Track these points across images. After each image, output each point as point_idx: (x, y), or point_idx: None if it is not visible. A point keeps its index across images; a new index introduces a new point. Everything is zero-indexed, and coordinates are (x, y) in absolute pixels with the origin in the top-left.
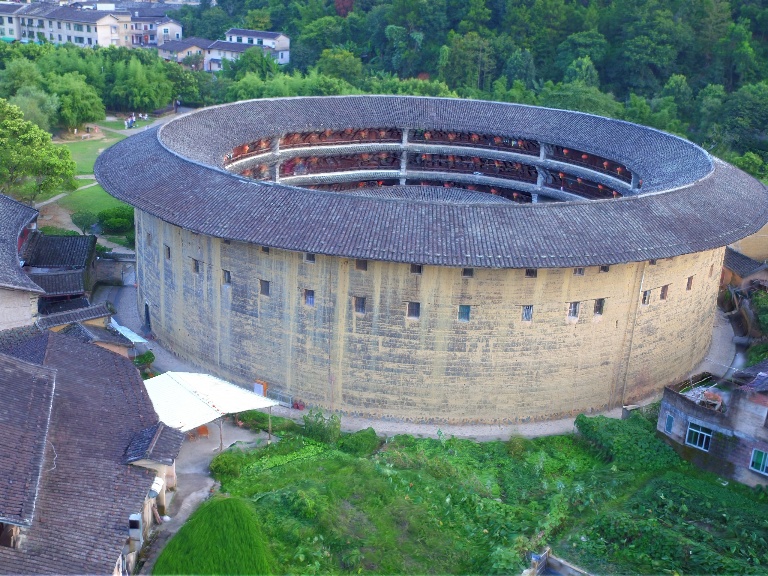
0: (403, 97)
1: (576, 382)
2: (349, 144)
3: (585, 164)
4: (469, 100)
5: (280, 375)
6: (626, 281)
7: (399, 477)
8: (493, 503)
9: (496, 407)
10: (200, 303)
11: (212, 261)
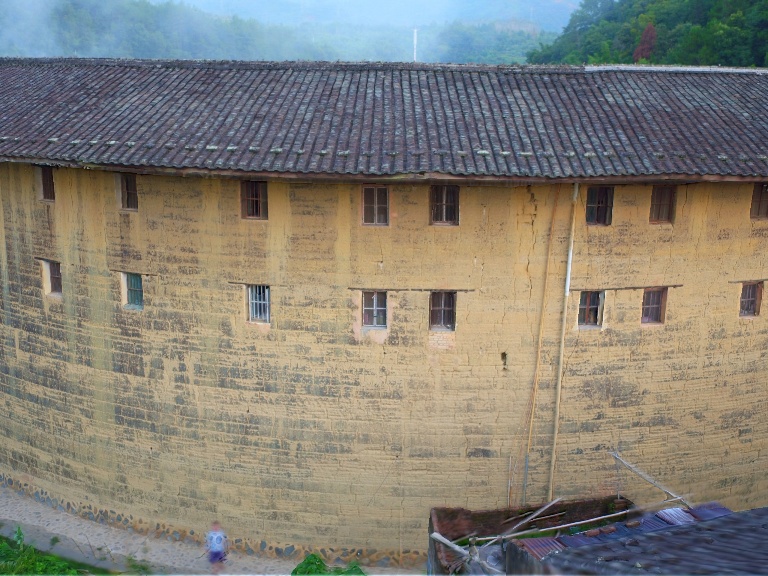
0: None
1: (401, 485)
2: None
3: None
4: None
5: None
6: (518, 256)
7: None
8: None
9: (217, 510)
10: None
11: None
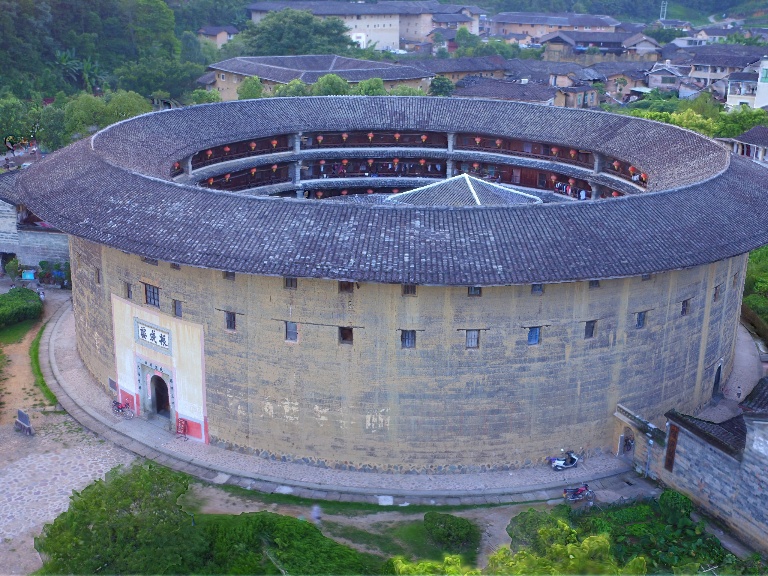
0: None
1: None
2: None
3: None
4: (94, 139)
5: None
6: None
7: None
8: None
9: None
10: None
11: None
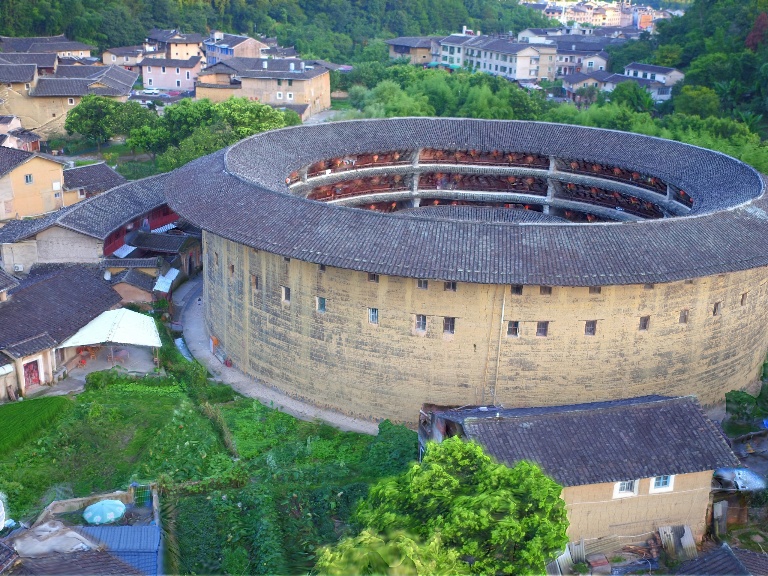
0: (568, 126)
1: (430, 396)
2: (498, 166)
3: None
4: (631, 133)
5: (223, 335)
6: (481, 305)
7: (186, 420)
8: (219, 457)
9: (352, 400)
10: None
11: (203, 233)
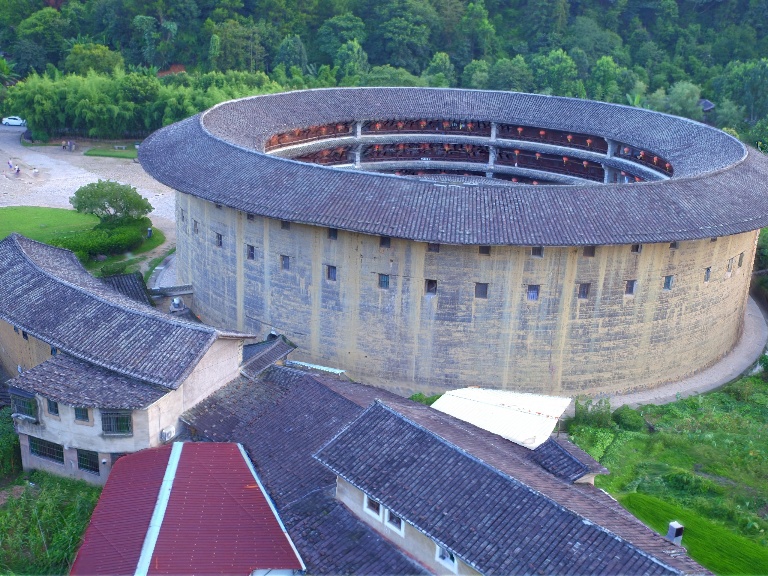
0: (341, 89)
1: (723, 330)
2: (310, 141)
3: (541, 140)
4: (402, 88)
5: (495, 376)
6: (752, 235)
7: None
8: None
9: (680, 365)
10: (388, 319)
11: (411, 273)
